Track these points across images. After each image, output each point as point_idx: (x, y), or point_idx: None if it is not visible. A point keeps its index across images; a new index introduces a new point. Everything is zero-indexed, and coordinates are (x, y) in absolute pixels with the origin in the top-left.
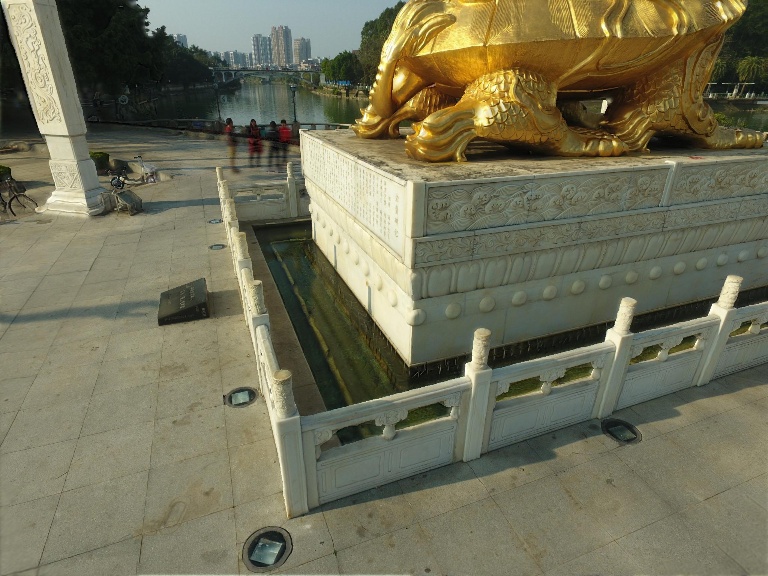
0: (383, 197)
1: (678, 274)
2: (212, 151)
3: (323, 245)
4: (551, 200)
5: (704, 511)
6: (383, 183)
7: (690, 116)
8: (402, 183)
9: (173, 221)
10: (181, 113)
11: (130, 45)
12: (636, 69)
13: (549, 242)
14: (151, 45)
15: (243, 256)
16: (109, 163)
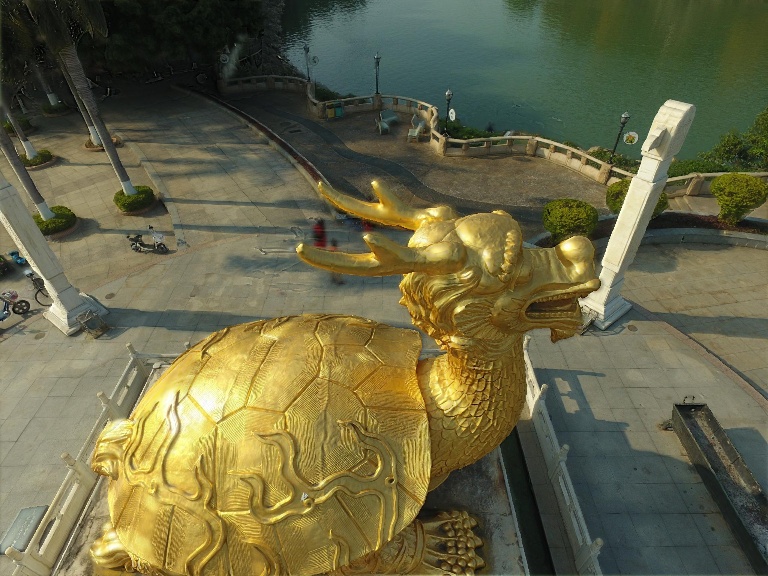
0: None
1: None
2: (246, 180)
3: None
4: None
5: None
6: None
7: (360, 574)
8: None
9: (114, 359)
10: (277, 69)
11: (221, 14)
12: None
13: None
14: (245, 5)
15: (15, 560)
16: (152, 200)
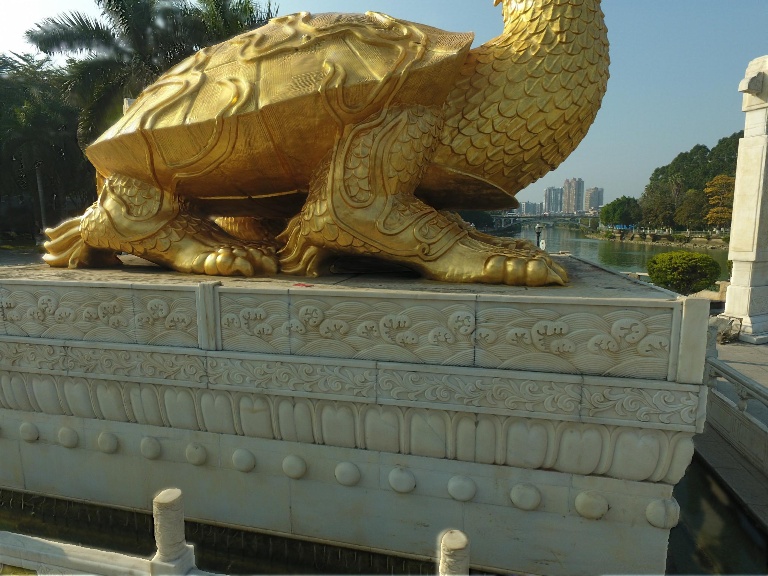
0: None
1: (298, 478)
2: None
3: None
4: (28, 312)
5: None
6: None
7: (359, 227)
8: None
9: None
10: None
11: None
12: (232, 166)
13: (31, 364)
14: None
15: None
16: None
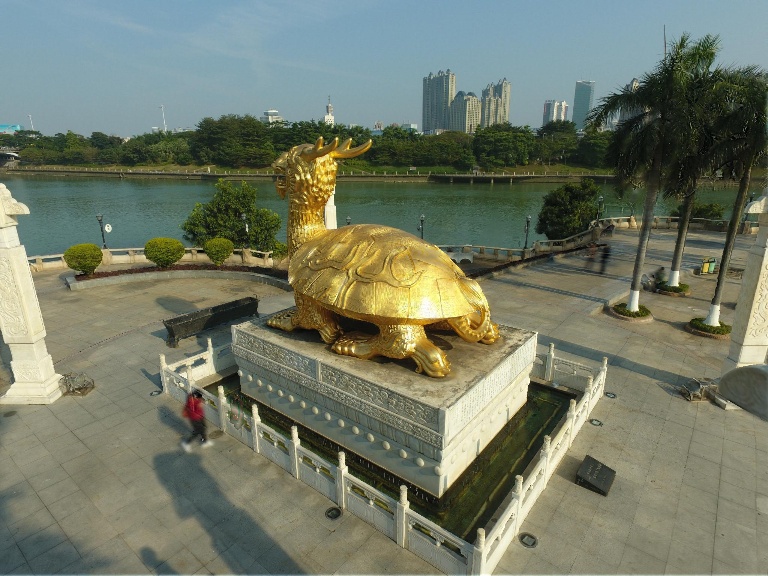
0: None
1: None
2: None
3: None
4: None
5: None
6: None
7: None
8: None
9: None
10: None
11: None
12: None
13: None
14: None
15: None
16: None
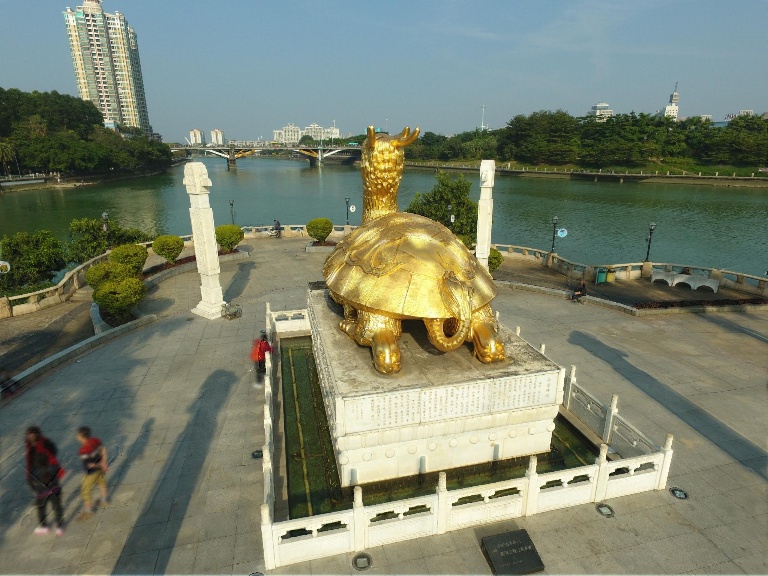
0: (533, 385)
1: None
2: None
3: (384, 474)
4: None
5: (607, 404)
6: (534, 379)
7: None
8: (557, 372)
9: None
10: None
11: None
12: None
13: None
14: None
15: None
16: None
